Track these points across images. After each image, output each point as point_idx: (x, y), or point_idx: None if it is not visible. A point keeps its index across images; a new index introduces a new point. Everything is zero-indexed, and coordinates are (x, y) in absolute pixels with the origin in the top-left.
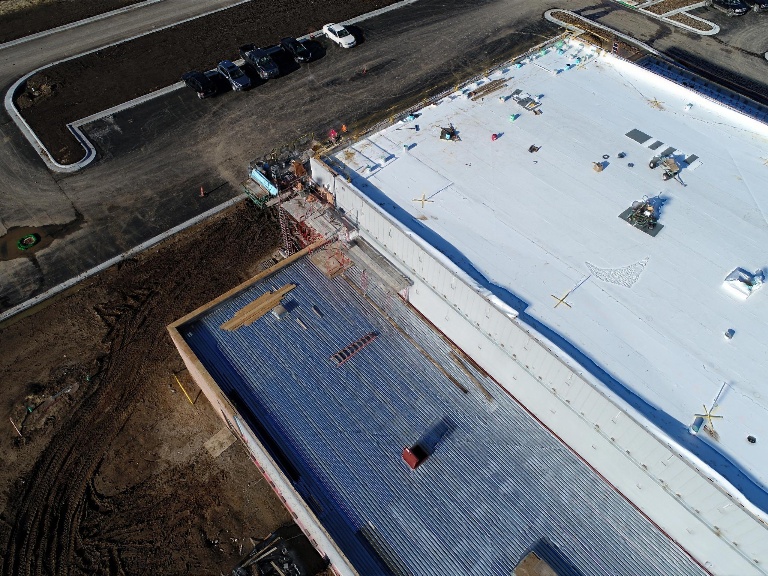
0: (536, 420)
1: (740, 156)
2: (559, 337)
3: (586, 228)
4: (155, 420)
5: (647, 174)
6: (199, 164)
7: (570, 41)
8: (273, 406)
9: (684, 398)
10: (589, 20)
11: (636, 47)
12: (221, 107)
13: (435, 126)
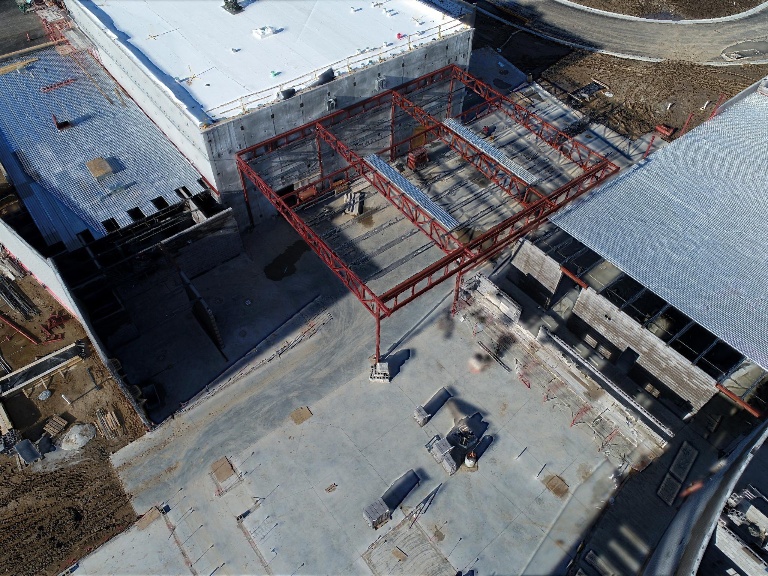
0: (145, 115)
1: None
2: (138, 50)
3: (196, 11)
4: None
5: None
6: (36, 24)
7: None
8: None
9: (186, 71)
10: None
11: None
12: None
13: None
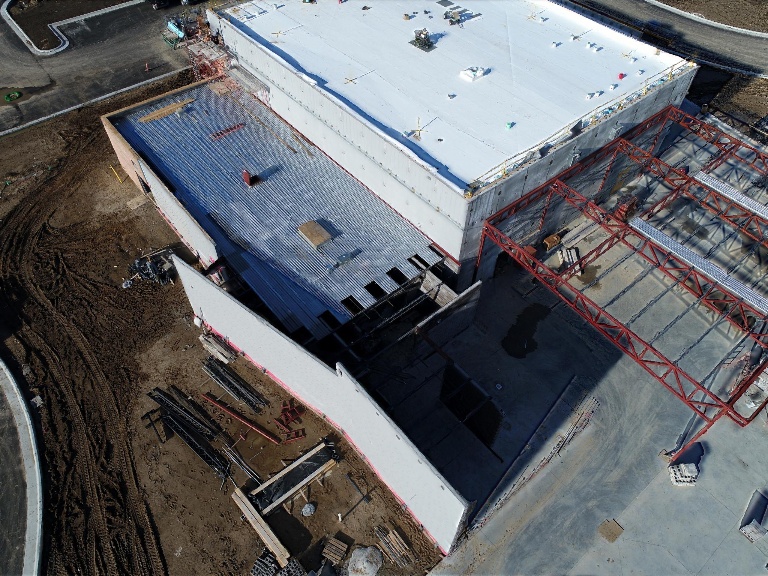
0: (339, 166)
1: (513, 15)
2: (342, 97)
3: (384, 48)
4: (94, 191)
5: (440, 22)
6: (148, 52)
7: None
8: (166, 159)
9: (408, 123)
10: None
11: None
12: None
13: None
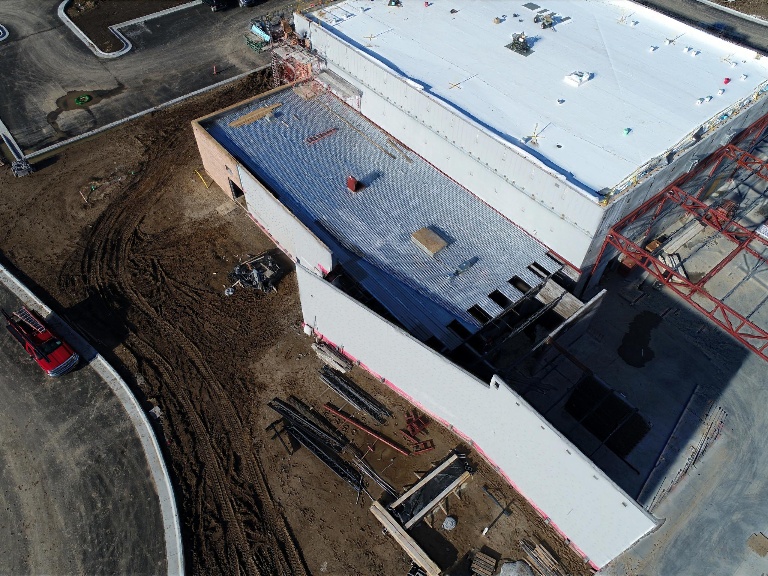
0: (440, 172)
1: (602, 18)
2: (449, 102)
3: (481, 52)
4: (181, 196)
5: (531, 26)
6: (212, 54)
7: None
8: (263, 164)
9: (522, 129)
10: None
11: None
12: (230, 18)
13: None
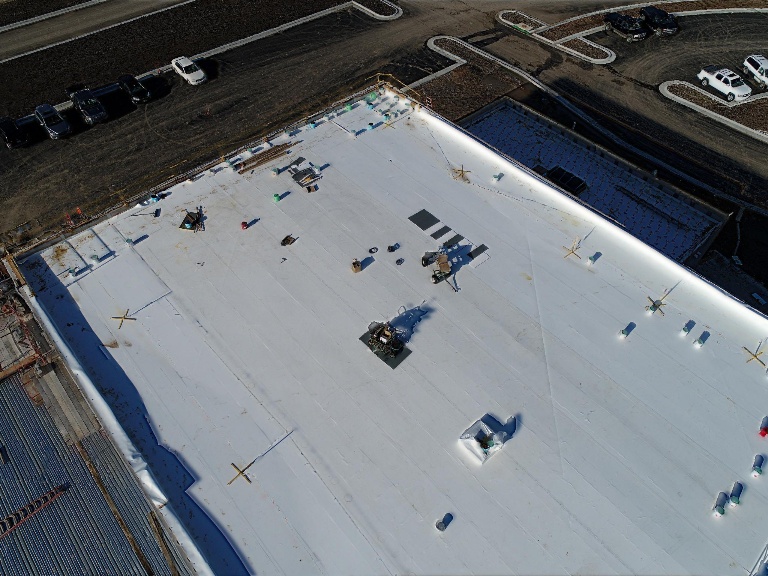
0: None
1: (539, 245)
2: (217, 533)
3: (313, 357)
4: None
5: (416, 274)
6: None
7: (386, 92)
8: None
9: None
10: (475, 48)
11: (519, 79)
12: (31, 159)
13: (180, 210)
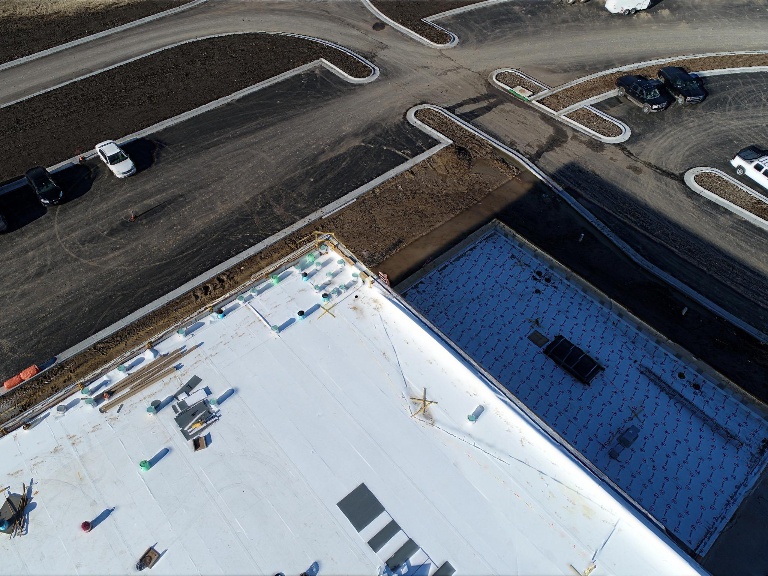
0: None
1: (533, 564)
2: None
3: None
4: None
5: None
6: None
7: (329, 251)
8: None
9: None
10: (463, 122)
11: (515, 166)
12: None
13: None
